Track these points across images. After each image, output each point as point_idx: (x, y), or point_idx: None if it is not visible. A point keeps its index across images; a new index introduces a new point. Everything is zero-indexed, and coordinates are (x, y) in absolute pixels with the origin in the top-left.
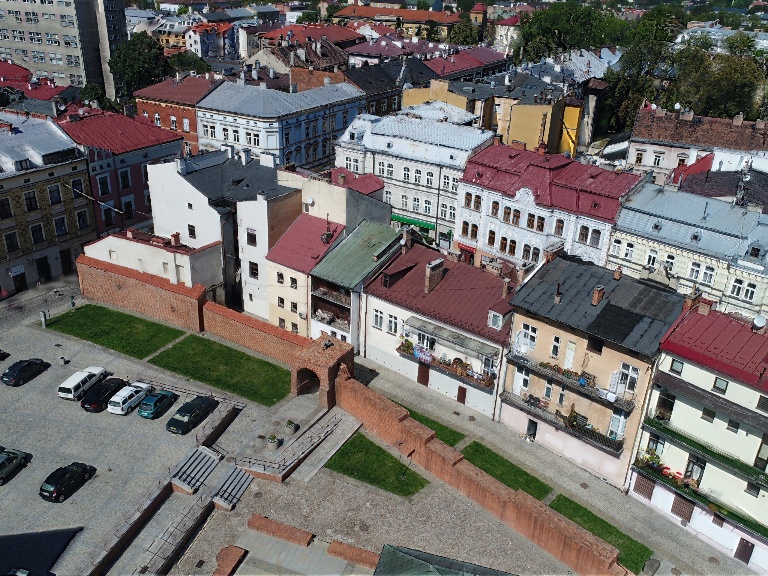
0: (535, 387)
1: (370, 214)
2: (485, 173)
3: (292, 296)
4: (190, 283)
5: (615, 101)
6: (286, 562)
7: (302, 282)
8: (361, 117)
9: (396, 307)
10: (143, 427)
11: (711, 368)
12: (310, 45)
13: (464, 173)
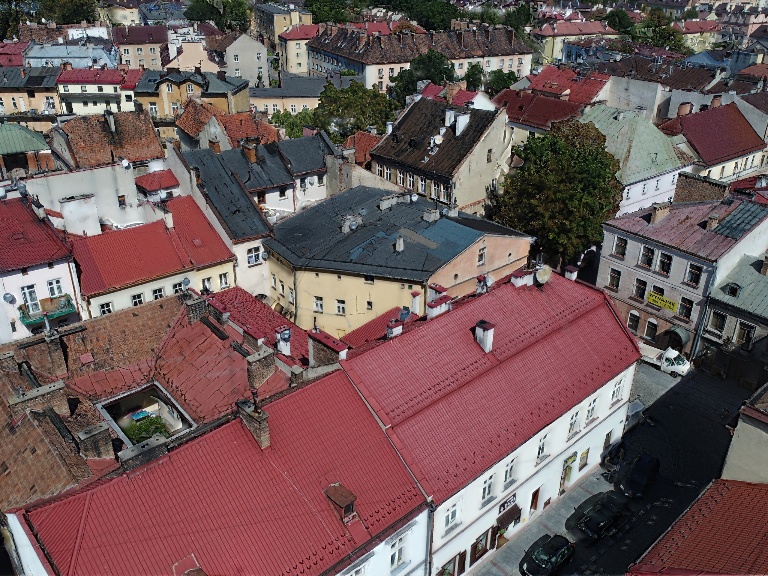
0: None
1: None
2: None
3: None
4: None
5: (1, 30)
6: None
7: None
8: None
9: None
10: None
11: (77, 82)
12: None
13: None
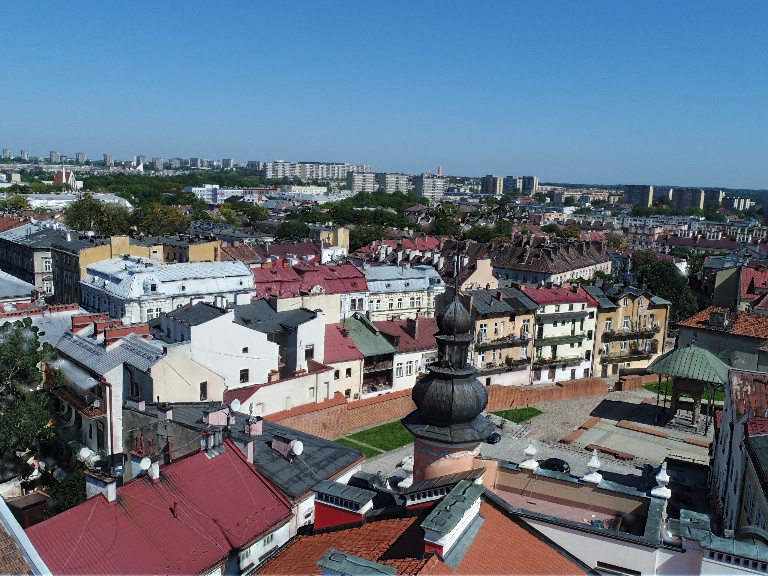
0: (489, 357)
1: None
2: (272, 287)
3: (347, 385)
4: (333, 394)
5: None
6: (595, 439)
7: (356, 368)
8: (143, 271)
9: (413, 354)
10: (487, 451)
11: (556, 302)
12: None
13: (256, 292)
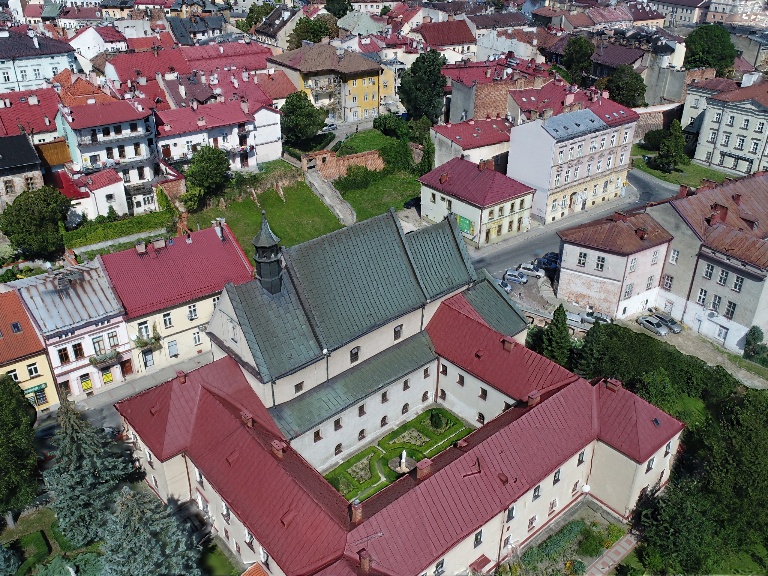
0: None
1: (48, 3)
2: None
3: None
4: None
5: None
6: None
7: None
8: None
9: (70, 20)
10: None
11: (144, 4)
12: None
13: None
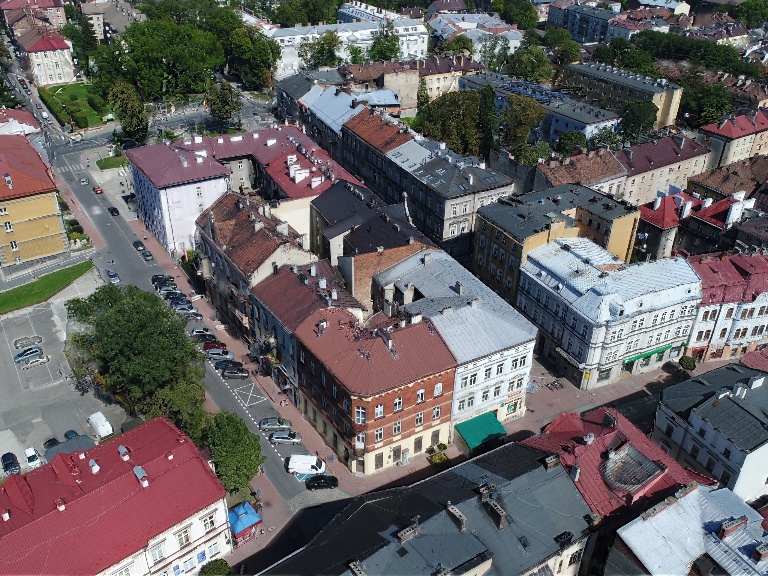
0: None
1: None
2: (717, 292)
3: None
4: None
5: None
6: None
7: None
8: (609, 292)
9: None
10: None
11: None
12: (253, 211)
13: (702, 299)
